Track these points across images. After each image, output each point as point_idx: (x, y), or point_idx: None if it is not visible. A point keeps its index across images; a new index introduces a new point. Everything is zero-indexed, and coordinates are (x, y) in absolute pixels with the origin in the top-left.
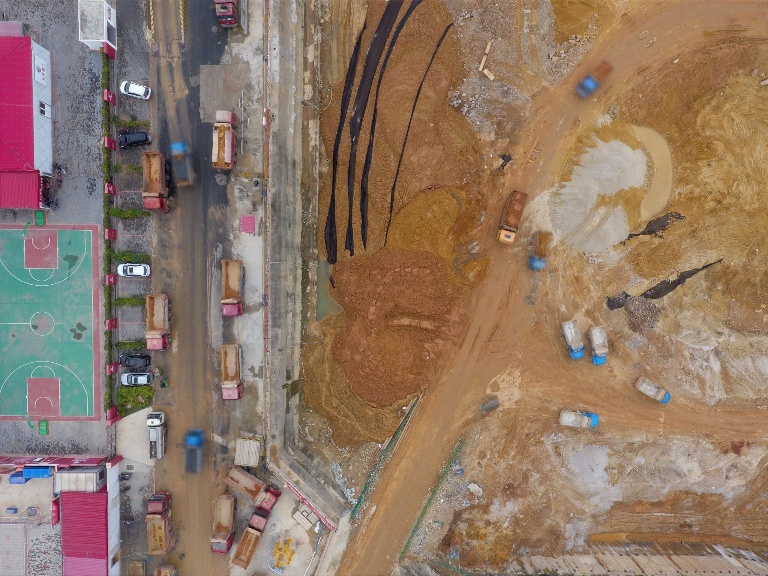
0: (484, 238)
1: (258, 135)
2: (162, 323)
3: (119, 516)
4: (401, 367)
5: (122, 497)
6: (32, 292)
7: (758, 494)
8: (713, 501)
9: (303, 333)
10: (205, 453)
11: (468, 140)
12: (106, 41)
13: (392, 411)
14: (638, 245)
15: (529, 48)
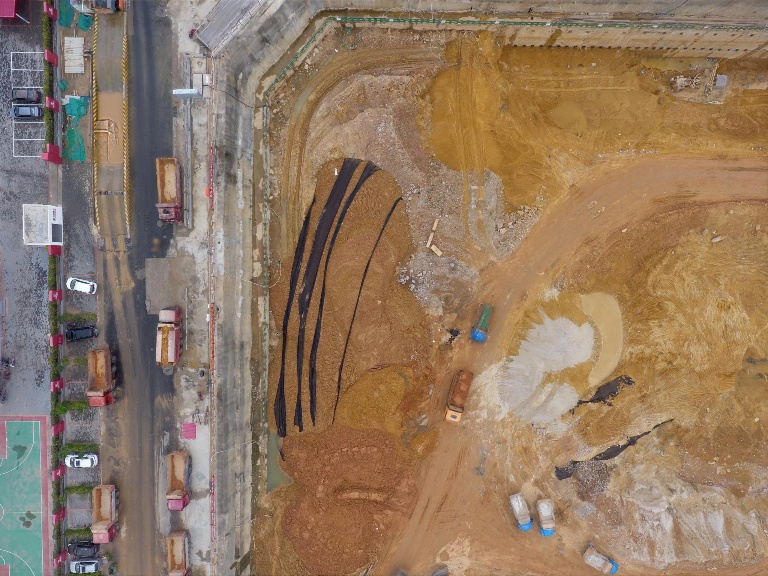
0: (433, 411)
1: (204, 326)
2: (109, 513)
3: None
4: (349, 544)
5: None
6: None
7: None
8: None
9: (254, 505)
10: None
11: (415, 317)
12: (50, 244)
13: None
14: (587, 414)
15: (476, 224)
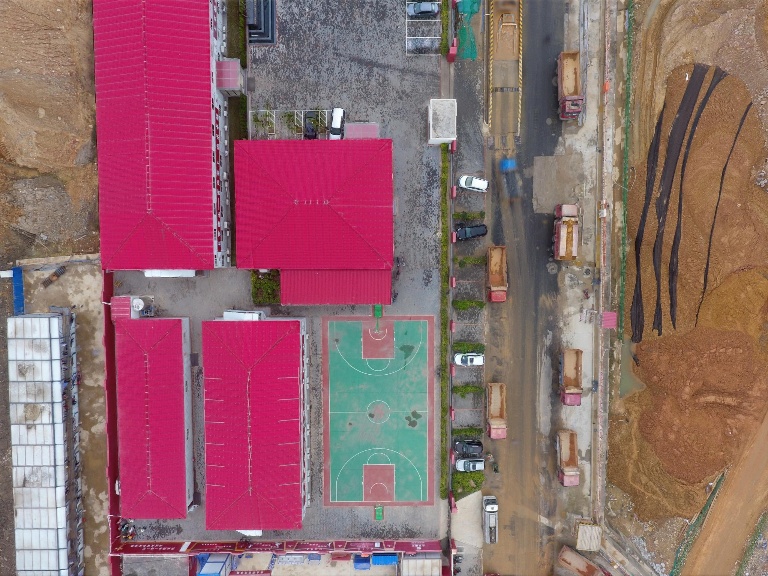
0: None
1: (590, 224)
2: (499, 411)
3: None
4: (713, 445)
5: None
6: (369, 382)
7: None
8: None
9: None
10: (532, 534)
11: None
12: None
13: (701, 488)
14: None
15: None
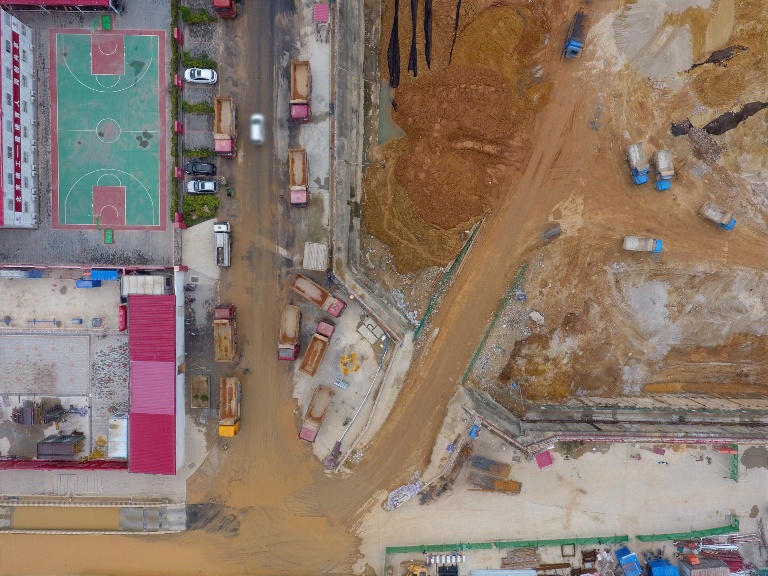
0: (548, 62)
1: None
2: (229, 129)
3: (184, 328)
4: (465, 187)
5: (187, 309)
6: (98, 98)
7: None
8: None
9: (365, 157)
10: (270, 266)
11: None
12: None
13: (455, 233)
14: (702, 73)
15: None
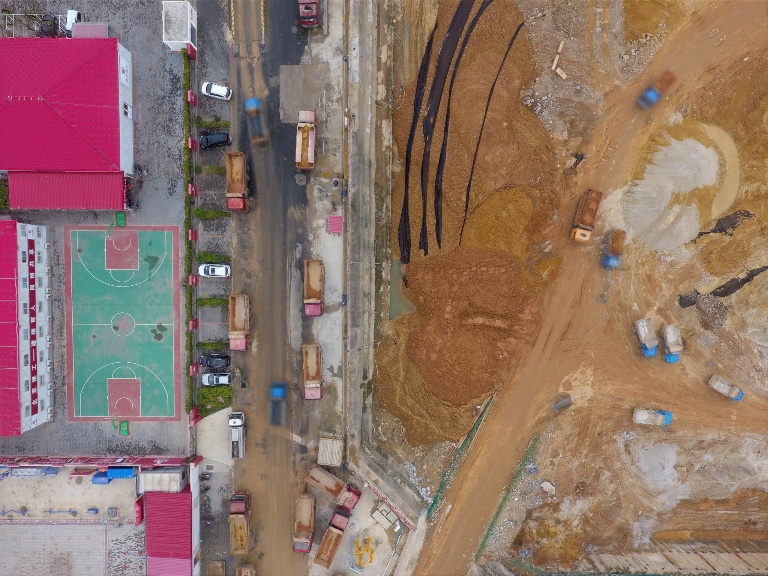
0: (557, 237)
1: (338, 135)
2: (243, 323)
3: (199, 516)
4: (477, 366)
5: (202, 497)
6: (113, 293)
7: None
8: None
9: (376, 333)
10: (284, 453)
11: (542, 139)
12: (190, 42)
13: (467, 410)
14: (709, 243)
15: (601, 47)
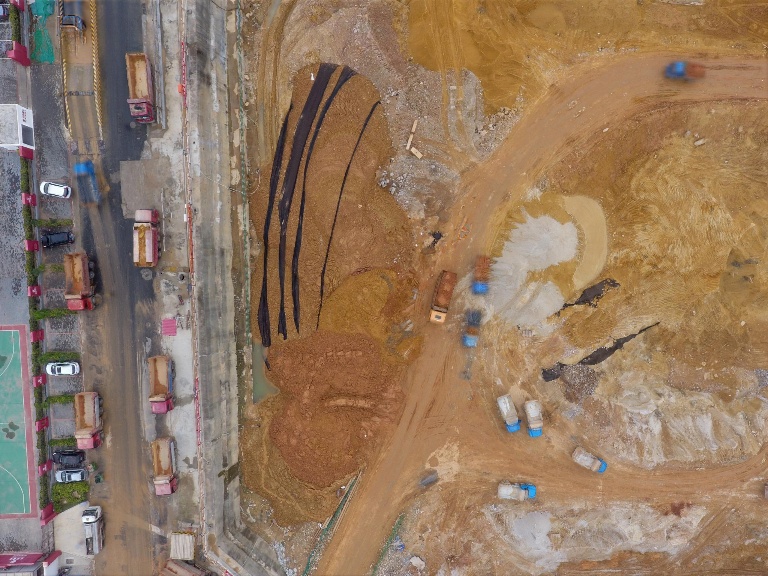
0: (417, 316)
1: (182, 229)
2: (93, 420)
3: None
4: (337, 449)
5: None
6: None
7: (702, 549)
8: (658, 558)
9: (241, 416)
10: (144, 544)
11: (397, 220)
12: (21, 145)
13: (331, 492)
14: (572, 316)
15: (456, 125)
